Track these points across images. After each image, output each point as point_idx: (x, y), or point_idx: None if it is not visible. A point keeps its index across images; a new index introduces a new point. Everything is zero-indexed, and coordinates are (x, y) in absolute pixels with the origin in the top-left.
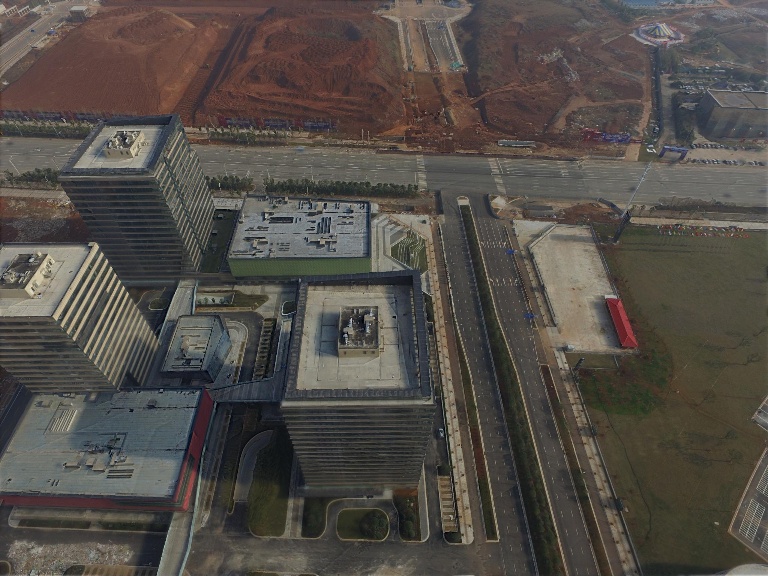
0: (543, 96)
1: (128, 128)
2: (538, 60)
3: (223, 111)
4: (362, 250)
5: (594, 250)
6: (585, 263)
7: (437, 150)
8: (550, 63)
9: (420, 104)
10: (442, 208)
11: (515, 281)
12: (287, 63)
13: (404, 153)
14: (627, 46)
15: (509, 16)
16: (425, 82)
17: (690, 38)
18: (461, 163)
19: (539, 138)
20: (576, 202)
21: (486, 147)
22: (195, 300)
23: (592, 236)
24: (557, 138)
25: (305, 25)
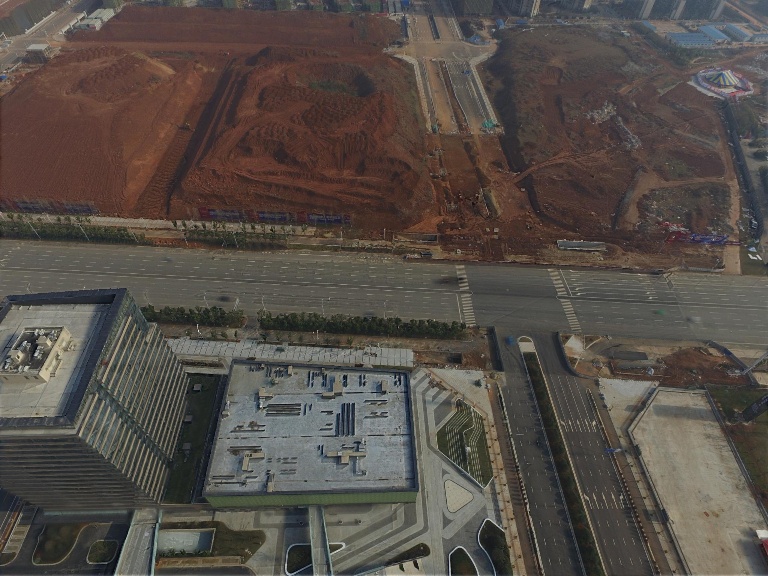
0: (603, 172)
1: (48, 310)
2: (587, 119)
3: (206, 196)
4: (404, 471)
5: (719, 435)
6: (713, 462)
7: (481, 256)
8: (602, 123)
9: (452, 182)
10: (500, 358)
11: (620, 498)
12: (286, 130)
13: (439, 262)
14: (688, 98)
15: (545, 58)
16: (454, 149)
17: (760, 88)
18: (515, 278)
19: (609, 237)
20: (676, 345)
21: (543, 251)
22: (155, 553)
23: (711, 408)
24: (632, 238)
25: (306, 71)
